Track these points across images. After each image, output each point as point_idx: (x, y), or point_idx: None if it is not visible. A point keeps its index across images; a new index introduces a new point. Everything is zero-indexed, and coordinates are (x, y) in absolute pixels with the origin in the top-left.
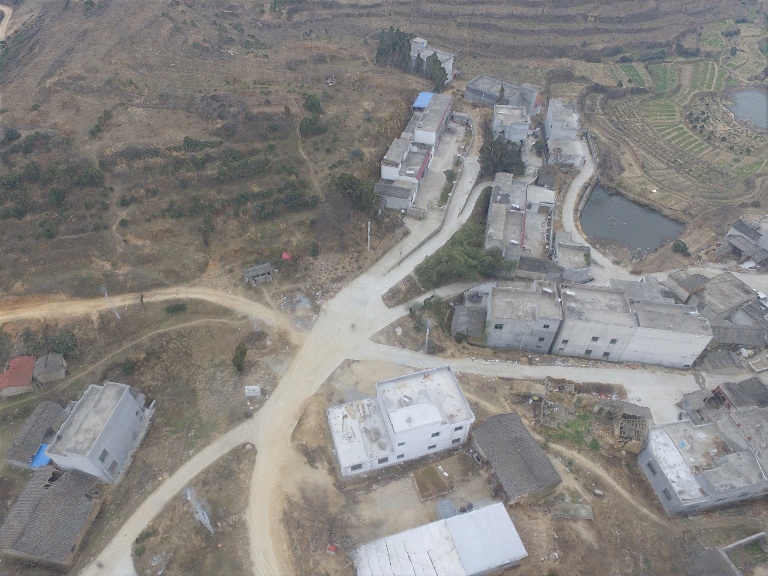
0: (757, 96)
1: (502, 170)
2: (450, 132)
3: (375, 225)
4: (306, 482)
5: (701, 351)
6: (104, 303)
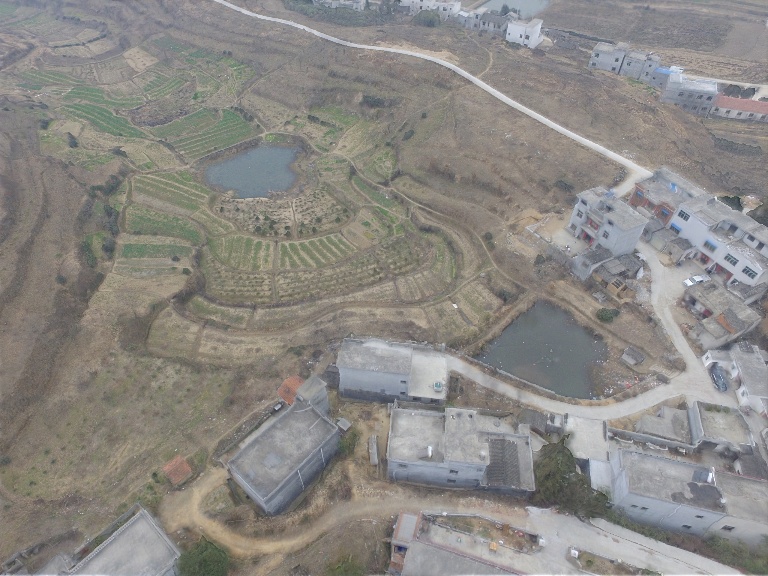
0: (220, 170)
1: None
2: None
3: None
4: None
5: None
6: None
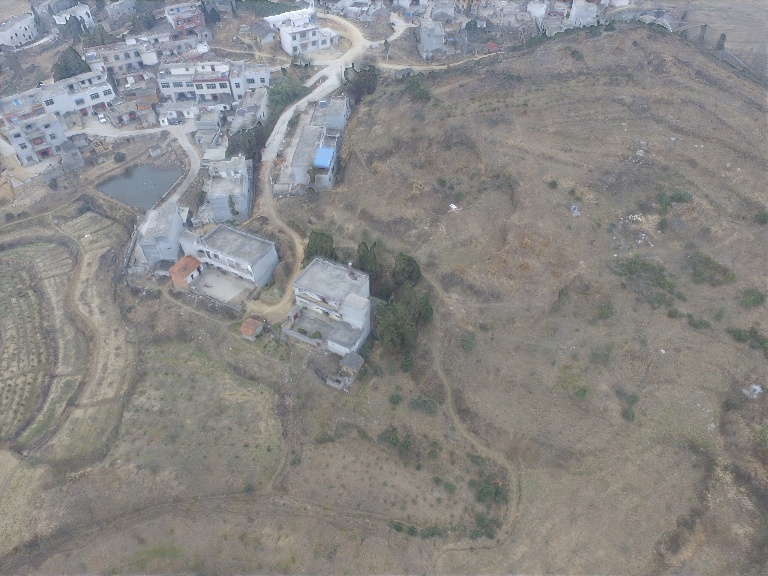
0: None
1: None
2: None
3: None
4: (340, 33)
5: None
6: None
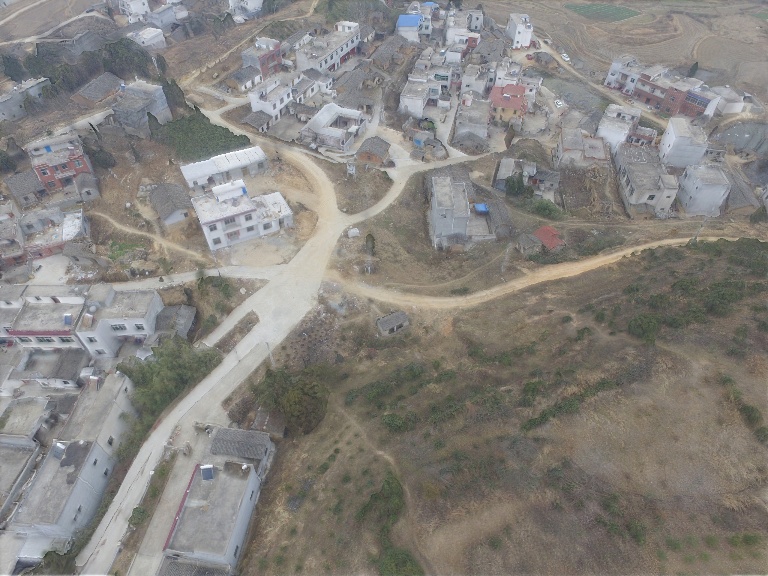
0: None
1: None
2: None
3: None
4: (302, 197)
5: None
6: (528, 281)
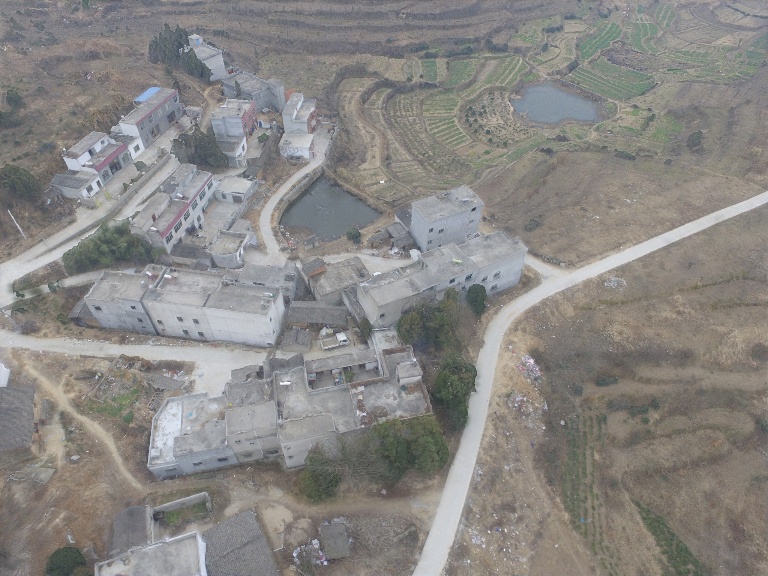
0: (549, 91)
1: (204, 162)
2: (177, 125)
3: (41, 214)
4: None
5: (269, 329)
6: None
